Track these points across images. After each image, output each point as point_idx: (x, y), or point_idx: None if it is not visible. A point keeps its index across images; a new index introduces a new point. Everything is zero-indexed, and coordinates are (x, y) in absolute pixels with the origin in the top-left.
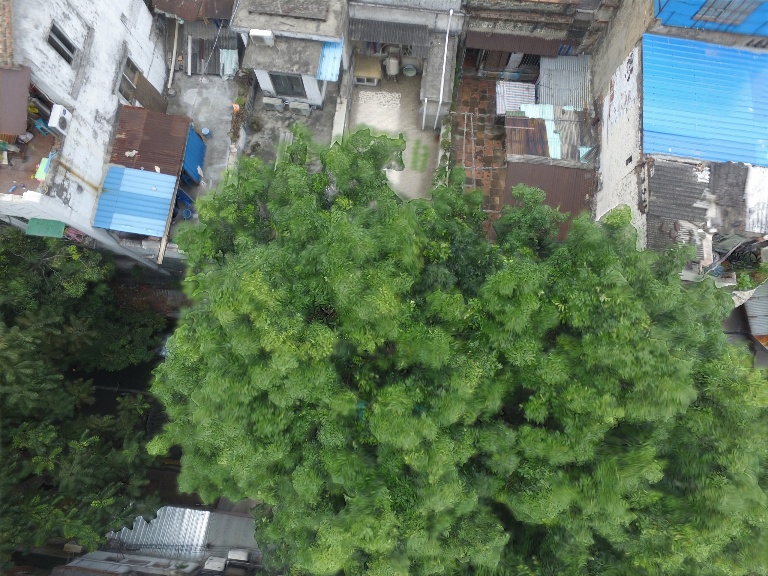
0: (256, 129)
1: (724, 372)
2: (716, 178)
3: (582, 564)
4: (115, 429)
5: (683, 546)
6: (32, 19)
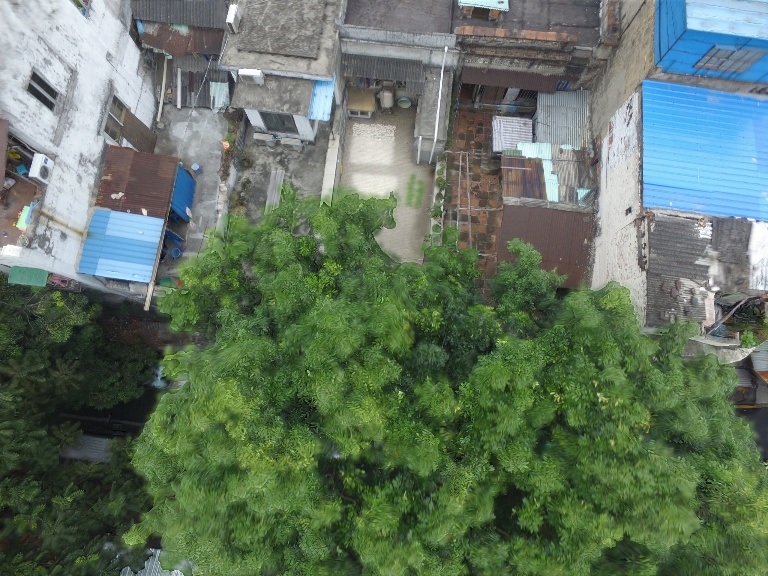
0: (247, 166)
1: (728, 474)
2: (719, 234)
3: None
4: (103, 474)
5: None
6: (10, 70)
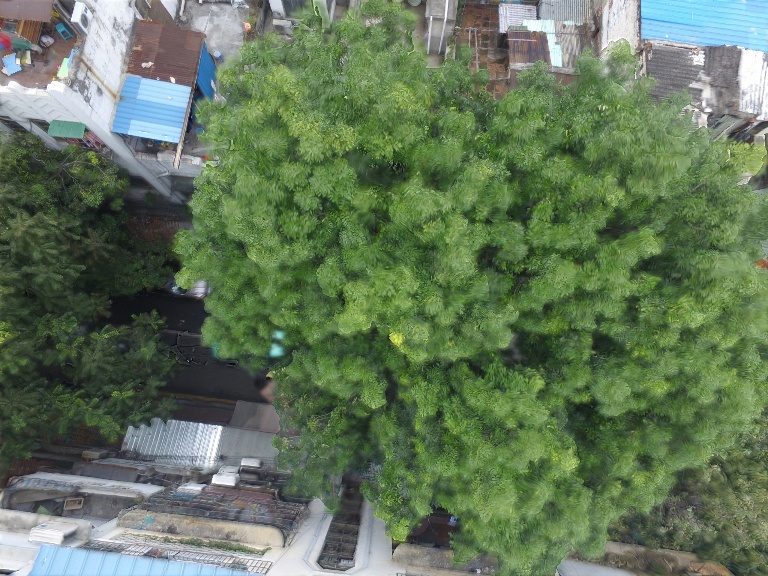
0: None
1: None
2: (711, 60)
3: (586, 357)
4: (131, 340)
5: (679, 313)
6: None
